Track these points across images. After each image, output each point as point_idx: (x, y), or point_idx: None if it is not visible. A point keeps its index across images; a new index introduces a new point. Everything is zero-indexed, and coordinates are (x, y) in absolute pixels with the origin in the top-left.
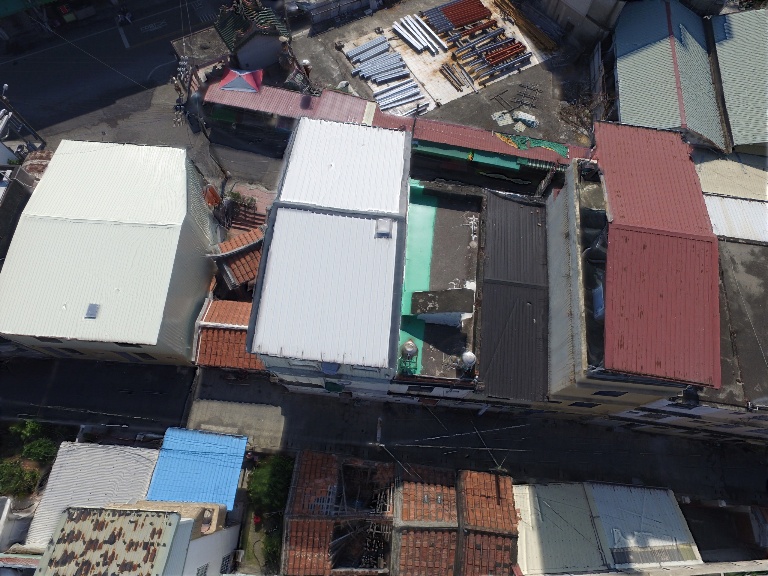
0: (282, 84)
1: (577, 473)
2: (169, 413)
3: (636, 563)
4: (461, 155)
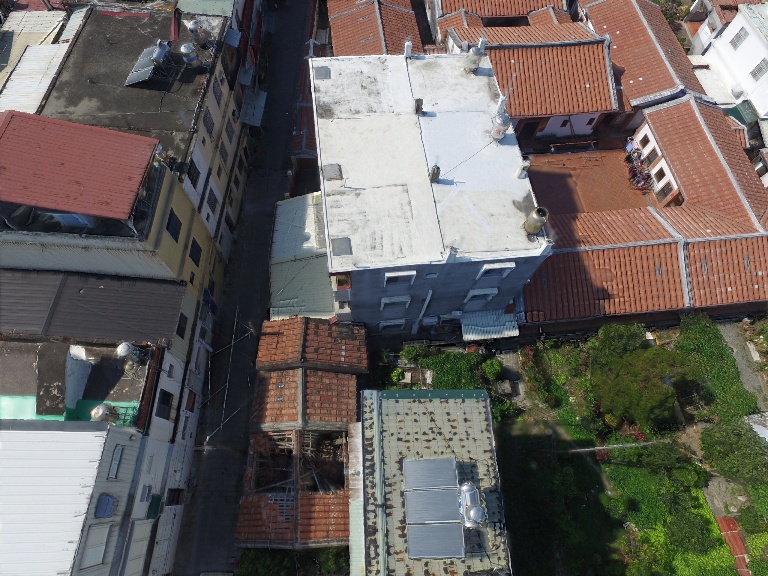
0: None
1: None
2: None
3: None
4: None
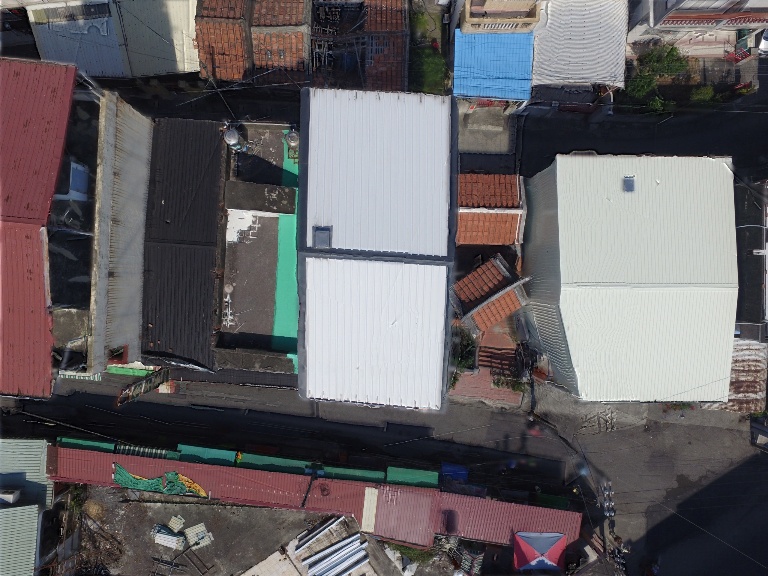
0: (487, 551)
1: (141, 106)
2: (535, 139)
3: (89, 5)
4: (251, 458)
